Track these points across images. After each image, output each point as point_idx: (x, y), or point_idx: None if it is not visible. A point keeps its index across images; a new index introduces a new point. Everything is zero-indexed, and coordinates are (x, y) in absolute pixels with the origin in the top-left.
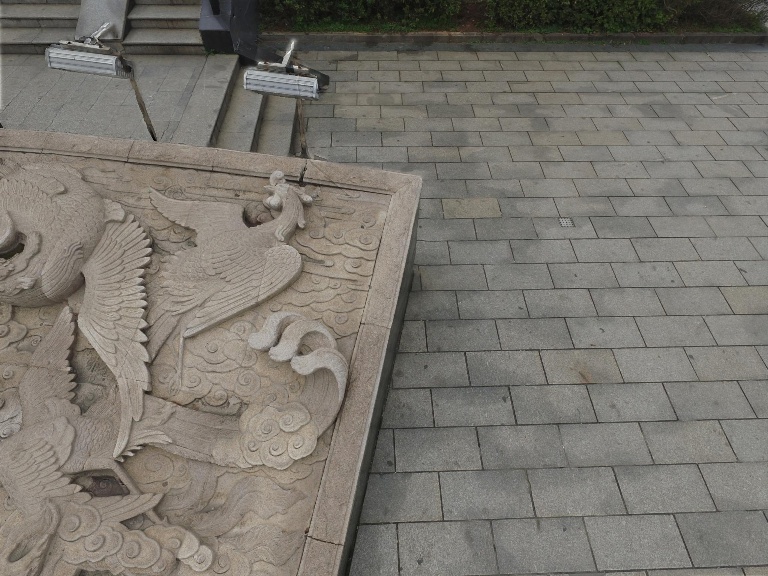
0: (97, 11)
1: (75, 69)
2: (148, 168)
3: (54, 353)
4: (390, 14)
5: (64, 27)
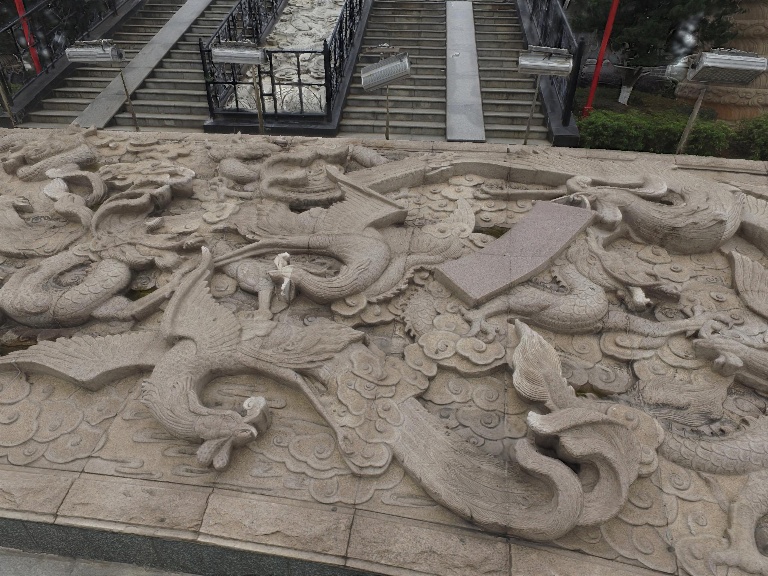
0: (461, 123)
1: (726, 67)
2: (700, 172)
3: (763, 282)
4: (660, 149)
5: (429, 134)
